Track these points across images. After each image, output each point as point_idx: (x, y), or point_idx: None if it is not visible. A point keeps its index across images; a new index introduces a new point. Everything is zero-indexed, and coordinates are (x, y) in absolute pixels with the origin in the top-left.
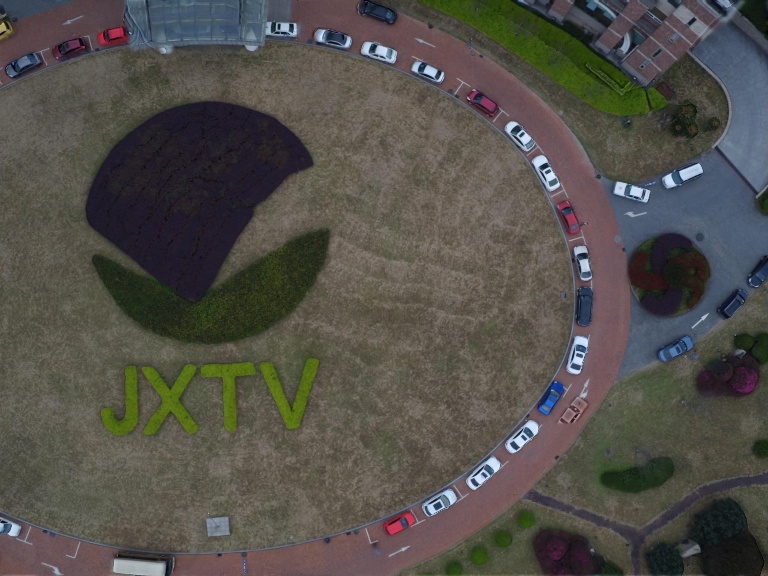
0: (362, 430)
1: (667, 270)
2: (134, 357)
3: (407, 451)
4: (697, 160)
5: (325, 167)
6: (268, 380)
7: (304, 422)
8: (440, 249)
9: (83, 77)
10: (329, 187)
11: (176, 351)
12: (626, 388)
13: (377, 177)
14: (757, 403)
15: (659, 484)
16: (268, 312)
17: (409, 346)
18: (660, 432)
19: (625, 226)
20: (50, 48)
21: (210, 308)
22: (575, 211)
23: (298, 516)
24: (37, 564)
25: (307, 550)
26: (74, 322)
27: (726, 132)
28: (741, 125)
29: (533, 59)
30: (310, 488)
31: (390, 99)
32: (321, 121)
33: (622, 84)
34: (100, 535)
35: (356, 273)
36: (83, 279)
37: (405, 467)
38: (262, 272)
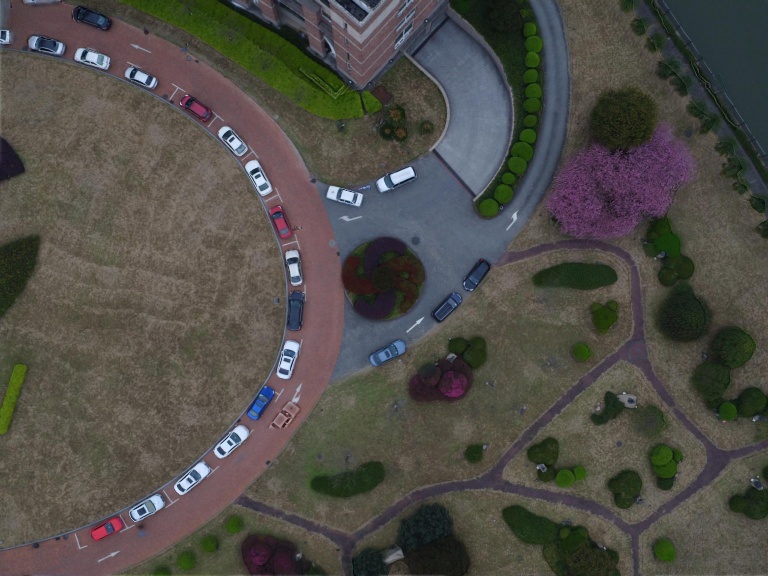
0: (71, 435)
1: (374, 274)
2: None
3: (116, 456)
4: (414, 163)
5: (37, 173)
6: None
7: (13, 428)
8: (151, 254)
9: None
10: (41, 193)
11: None
12: (339, 393)
13: (89, 183)
14: (471, 407)
15: (368, 489)
16: None
17: (119, 351)
18: (372, 437)
19: (340, 230)
20: None
21: None
22: (288, 215)
23: (7, 521)
24: None
25: (16, 555)
26: None
27: (444, 135)
28: (461, 128)
29: (247, 64)
30: (19, 493)
31: (104, 105)
32: (34, 128)
33: (336, 88)
34: None
35: (66, 279)
36: None
37: (114, 472)
38: None
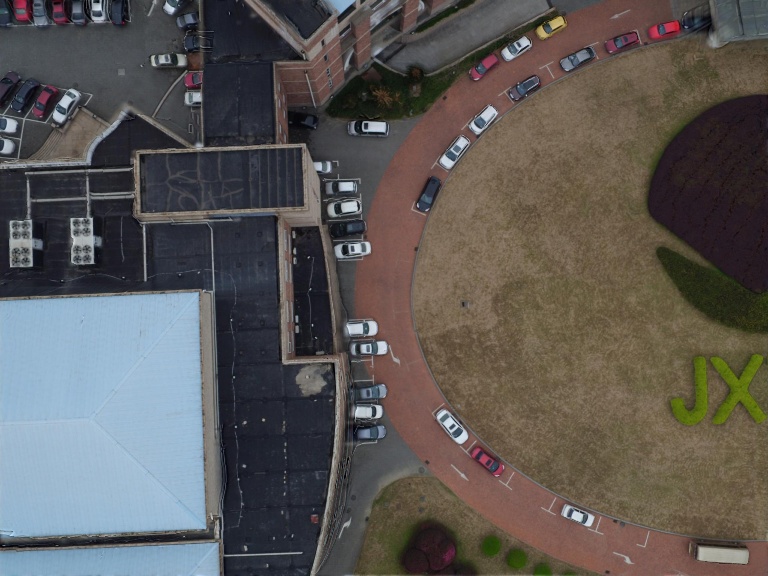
0: None
1: None
2: (700, 348)
3: None
4: None
5: None
6: None
7: None
8: None
9: (634, 71)
10: None
11: (741, 341)
12: None
13: None
14: None
15: None
16: None
17: None
18: None
19: None
20: (600, 42)
21: None
22: None
23: None
24: (608, 554)
25: None
26: (640, 314)
27: None
28: None
29: None
30: None
31: None
32: None
33: None
34: (670, 524)
35: None
36: (647, 271)
37: None
38: None
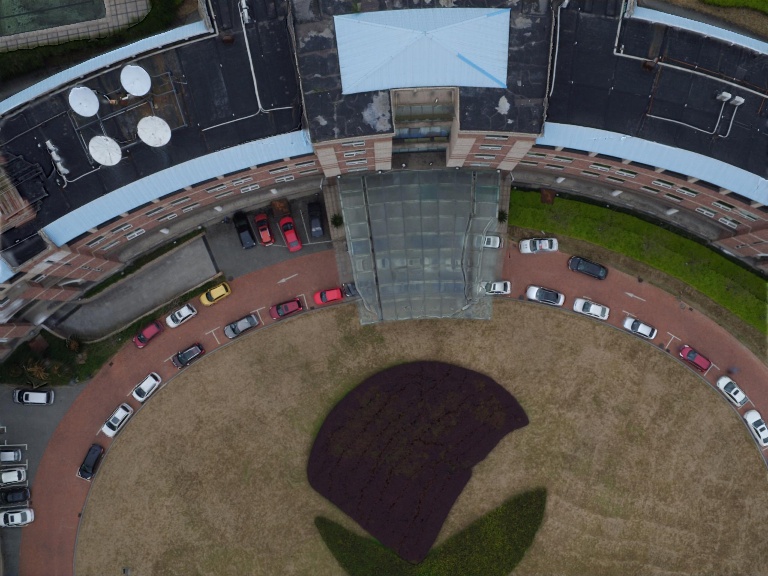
0: None
1: None
2: None
3: None
4: None
5: (540, 425)
6: None
7: None
8: (655, 505)
9: (299, 336)
10: (544, 445)
11: None
12: None
13: (591, 434)
14: None
15: None
16: (489, 573)
17: None
18: None
19: None
20: (266, 307)
21: (432, 570)
22: None
23: None
24: None
25: None
26: None
27: None
28: None
29: (744, 313)
30: None
31: (602, 355)
32: (535, 378)
33: None
34: None
35: (573, 531)
36: (305, 540)
37: None
38: (482, 533)
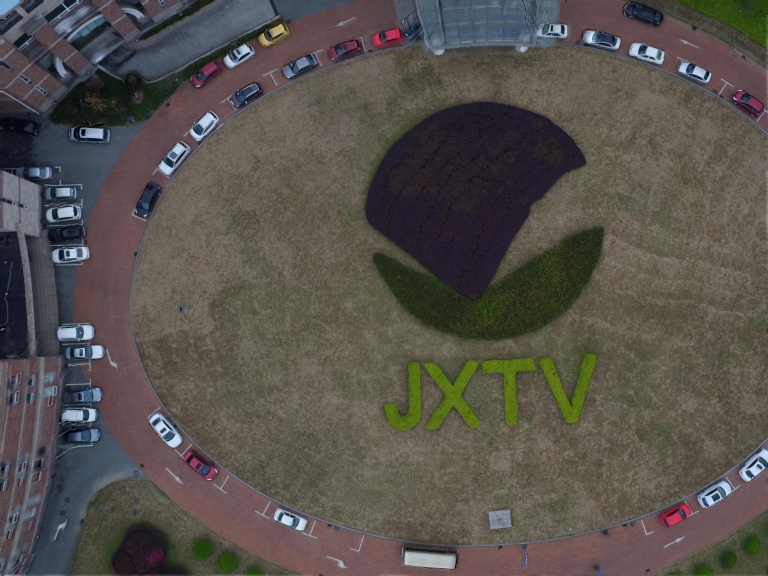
0: (637, 424)
1: None
2: (415, 354)
3: (681, 444)
4: None
5: (596, 166)
6: (548, 375)
7: (581, 416)
8: (709, 246)
9: (357, 78)
10: (601, 186)
11: (457, 347)
12: None
13: (647, 176)
14: None
15: None
16: (547, 309)
17: (681, 341)
18: None
19: None
20: (324, 49)
21: (491, 305)
22: None
23: (577, 508)
24: (322, 557)
25: (585, 542)
26: (356, 319)
27: None
28: None
29: None
30: (588, 481)
31: (657, 99)
32: (591, 121)
33: None
34: (384, 528)
35: (629, 270)
36: (364, 277)
37: (679, 460)
38: (540, 269)
